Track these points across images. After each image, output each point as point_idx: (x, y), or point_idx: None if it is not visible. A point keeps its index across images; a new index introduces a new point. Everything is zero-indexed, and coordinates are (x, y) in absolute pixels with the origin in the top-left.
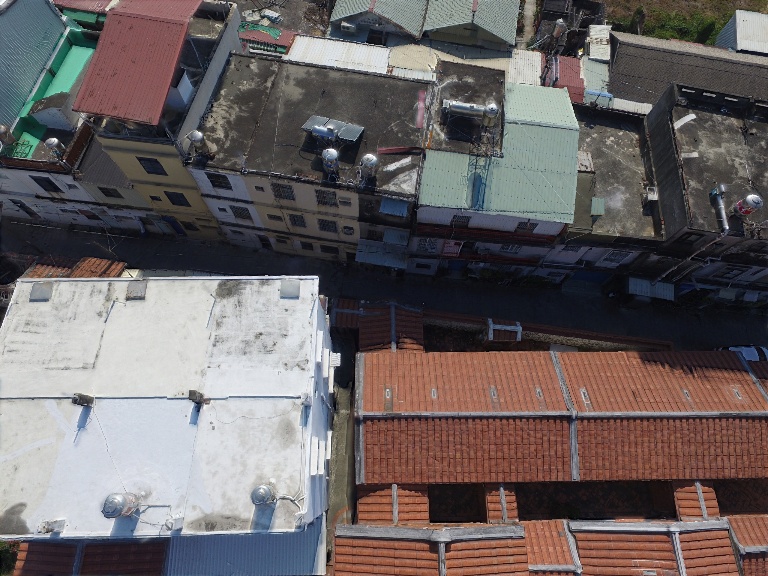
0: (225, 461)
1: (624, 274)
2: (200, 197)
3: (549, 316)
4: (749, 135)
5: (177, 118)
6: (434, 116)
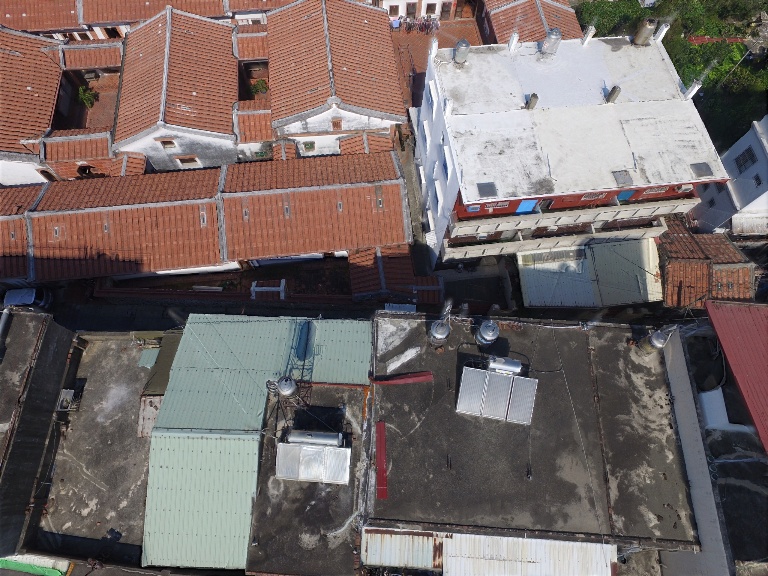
0: (495, 78)
1: None
2: None
3: None
4: None
5: (701, 385)
6: (361, 449)
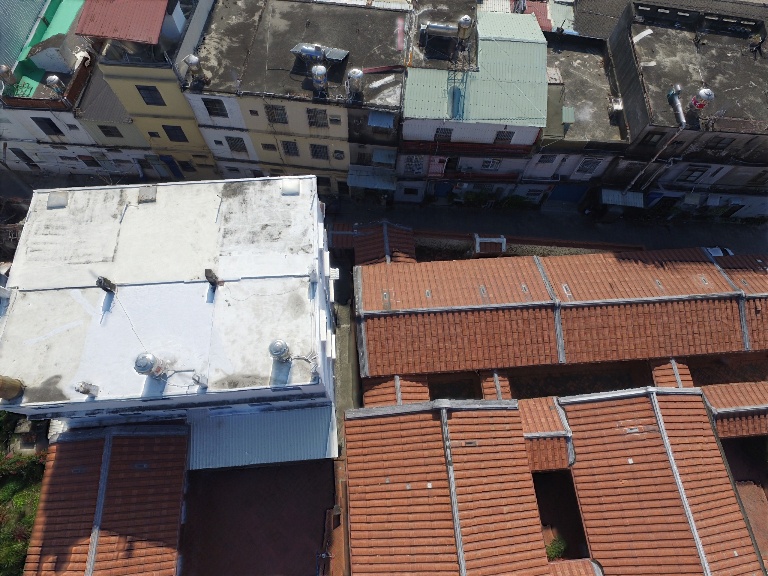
0: (242, 331)
1: (597, 186)
2: (197, 129)
3: (531, 234)
4: (701, 45)
5: (172, 48)
6: (413, 39)
